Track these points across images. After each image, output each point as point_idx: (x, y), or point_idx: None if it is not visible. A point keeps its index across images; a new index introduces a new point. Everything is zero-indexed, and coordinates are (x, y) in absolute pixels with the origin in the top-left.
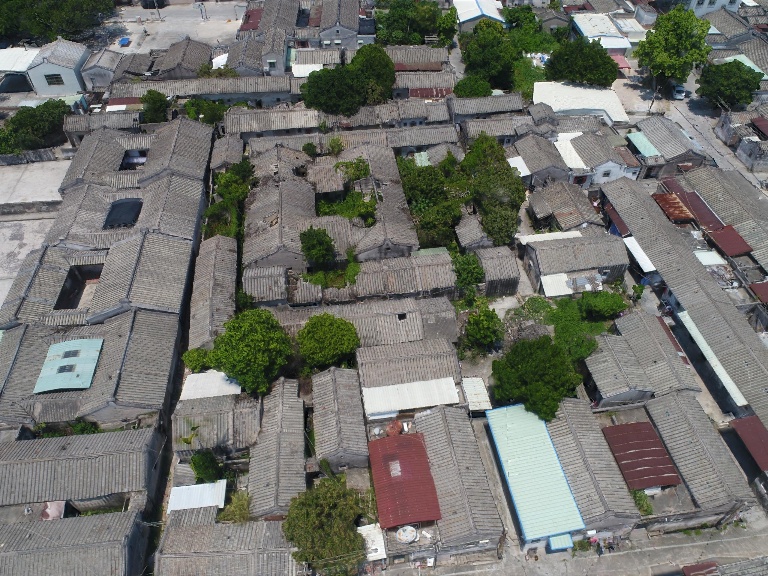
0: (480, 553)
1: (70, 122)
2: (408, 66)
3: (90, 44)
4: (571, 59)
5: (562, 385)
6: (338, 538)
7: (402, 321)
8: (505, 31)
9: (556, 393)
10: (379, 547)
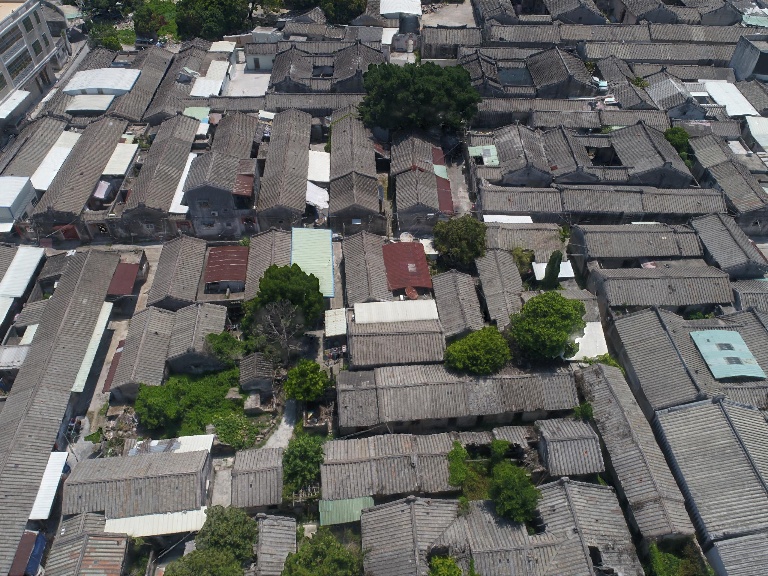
0: None
1: None
2: None
3: None
4: None
5: None
6: None
7: None
8: None
9: None
10: (424, 244)
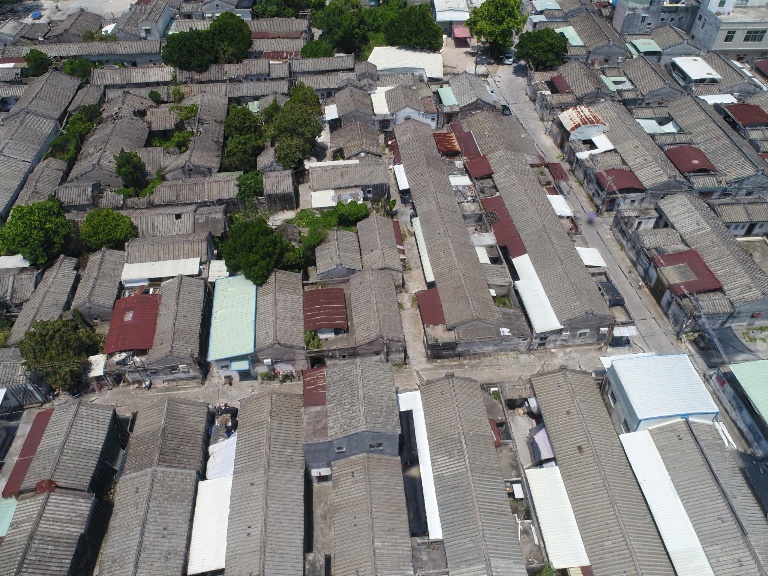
0: (189, 380)
1: None
2: (271, 34)
3: (6, 17)
4: (400, 25)
5: (269, 256)
6: (55, 351)
7: (178, 220)
8: (374, 8)
9: (264, 262)
10: (100, 368)
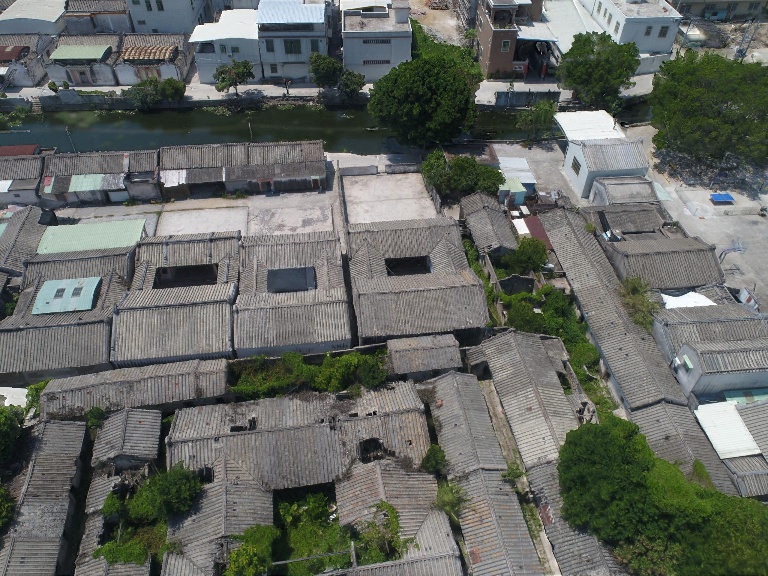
0: None
1: (473, 198)
2: None
3: (699, 173)
4: None
5: None
6: None
7: None
8: None
9: None
10: None
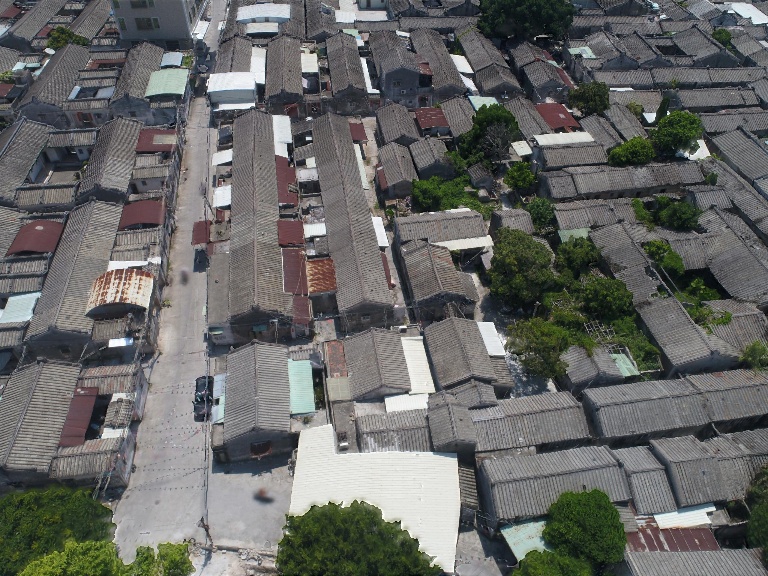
0: None
1: None
2: None
3: None
4: None
5: None
6: None
7: None
8: None
9: None
10: None
